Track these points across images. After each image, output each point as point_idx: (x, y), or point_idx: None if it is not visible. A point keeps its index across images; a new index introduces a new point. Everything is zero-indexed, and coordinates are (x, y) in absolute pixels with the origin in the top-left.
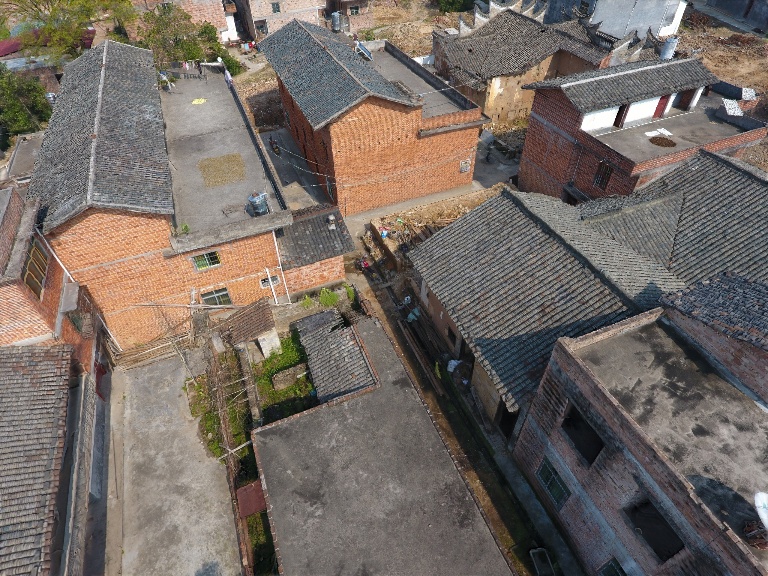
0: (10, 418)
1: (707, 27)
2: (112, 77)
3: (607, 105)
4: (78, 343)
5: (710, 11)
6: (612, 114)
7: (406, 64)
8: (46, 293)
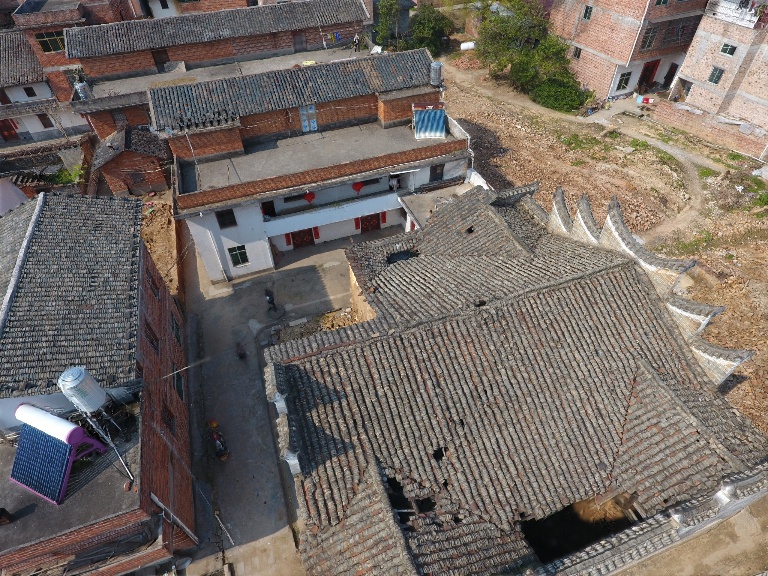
0: (4, 73)
1: None
2: (269, 9)
3: None
4: (64, 87)
5: None
6: None
7: (395, 163)
8: (55, 54)
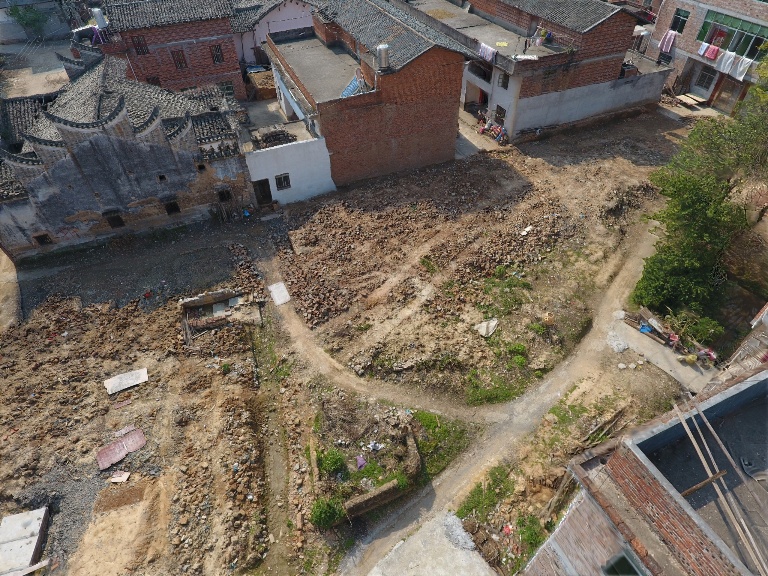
0: None
1: None
2: None
3: None
4: None
5: None
6: None
7: None
8: None
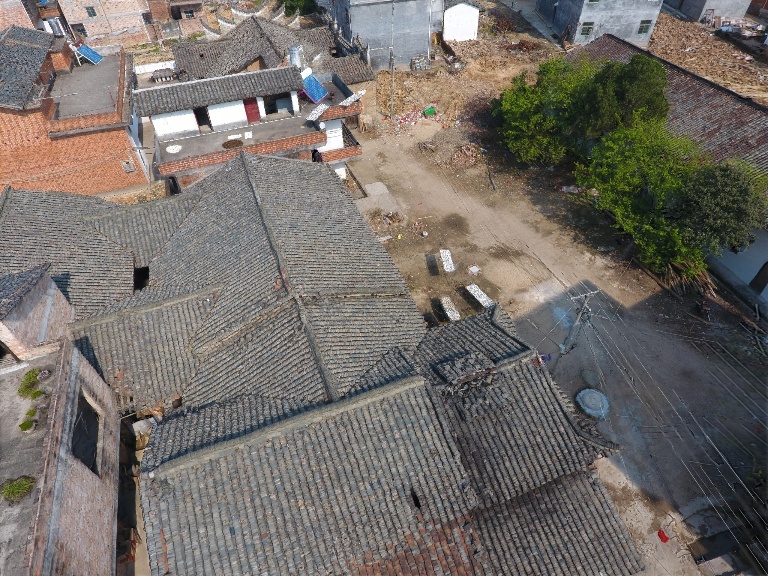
0: None
1: (511, 32)
2: None
3: (167, 110)
4: None
5: (532, 16)
6: (189, 118)
7: None
8: None
